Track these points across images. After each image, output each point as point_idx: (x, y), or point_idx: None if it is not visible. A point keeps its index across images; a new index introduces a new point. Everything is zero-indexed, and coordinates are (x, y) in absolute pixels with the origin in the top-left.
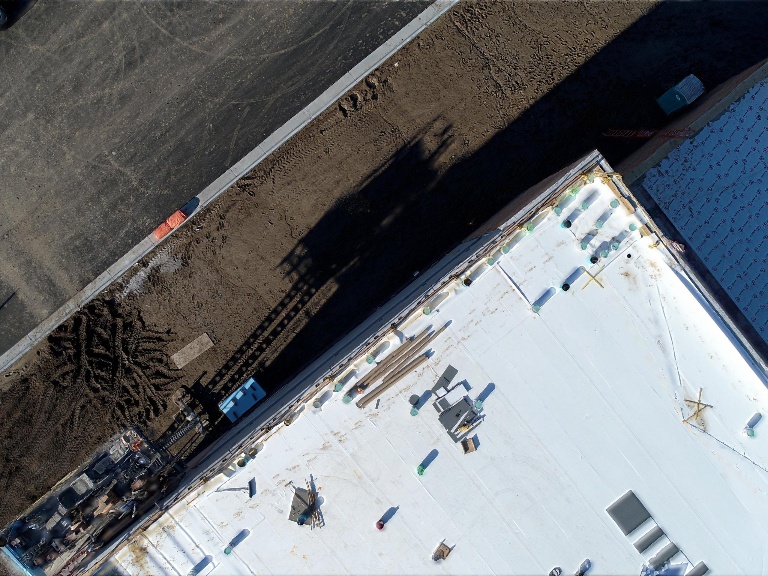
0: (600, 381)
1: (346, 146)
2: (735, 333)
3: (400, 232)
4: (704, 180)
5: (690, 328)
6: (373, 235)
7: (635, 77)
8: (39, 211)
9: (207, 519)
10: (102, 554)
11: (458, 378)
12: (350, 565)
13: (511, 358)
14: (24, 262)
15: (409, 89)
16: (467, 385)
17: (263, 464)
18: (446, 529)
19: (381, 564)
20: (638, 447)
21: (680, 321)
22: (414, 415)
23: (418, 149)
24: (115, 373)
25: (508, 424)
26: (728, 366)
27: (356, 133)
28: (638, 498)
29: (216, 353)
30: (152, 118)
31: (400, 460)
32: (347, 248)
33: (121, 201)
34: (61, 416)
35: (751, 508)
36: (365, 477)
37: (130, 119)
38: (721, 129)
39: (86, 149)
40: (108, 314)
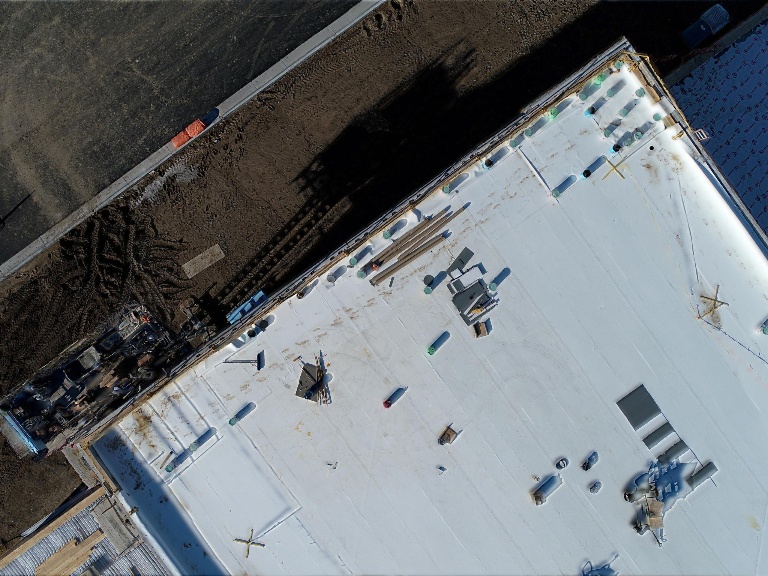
0: (616, 272)
1: (368, 65)
2: (755, 228)
3: (417, 153)
4: (727, 100)
5: (710, 224)
6: (390, 155)
7: (660, 11)
8: (59, 114)
9: (213, 391)
10: (106, 418)
11: (474, 261)
12: (355, 445)
13: (528, 244)
14: (41, 164)
15: (434, 12)
16: (482, 268)
17: (273, 337)
18: (454, 413)
19: (386, 446)
20: (652, 341)
21: (700, 216)
22: (428, 293)
23: (440, 71)
24: (125, 280)
25: (522, 310)
26: (747, 264)
27: (379, 53)
28: (649, 393)
29: (227, 265)
30: (177, 28)
31: (411, 340)
32: (364, 166)
33: (141, 108)
34: (68, 320)
35: (764, 410)
36: (375, 356)
37: (155, 28)
38: (746, 50)
39: (110, 55)
40: (121, 220)
